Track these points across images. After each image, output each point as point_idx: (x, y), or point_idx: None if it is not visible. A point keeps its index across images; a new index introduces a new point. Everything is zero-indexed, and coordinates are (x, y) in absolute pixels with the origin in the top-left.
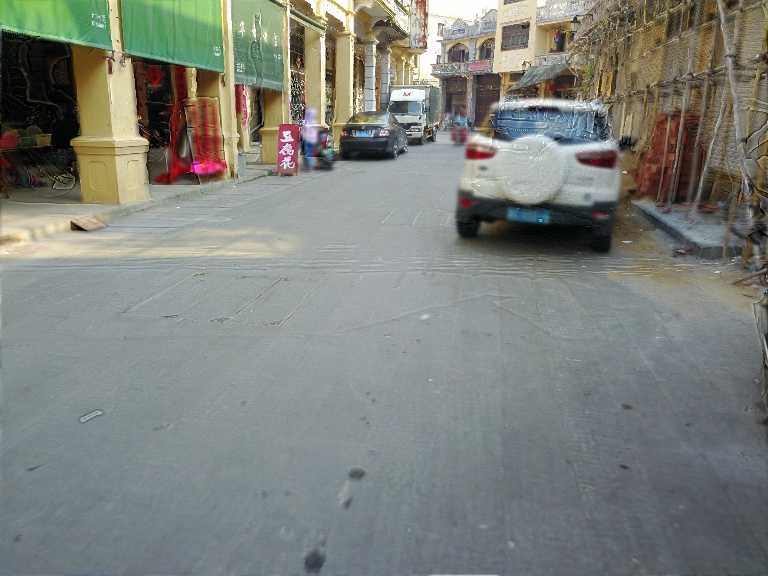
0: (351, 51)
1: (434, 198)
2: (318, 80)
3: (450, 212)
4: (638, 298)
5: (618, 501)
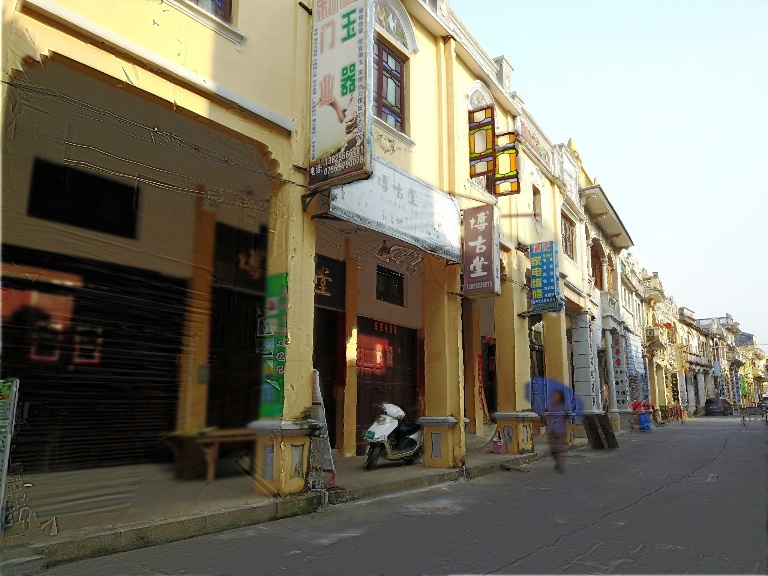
0: (753, 386)
1: None
2: (751, 394)
3: None
4: None
5: None
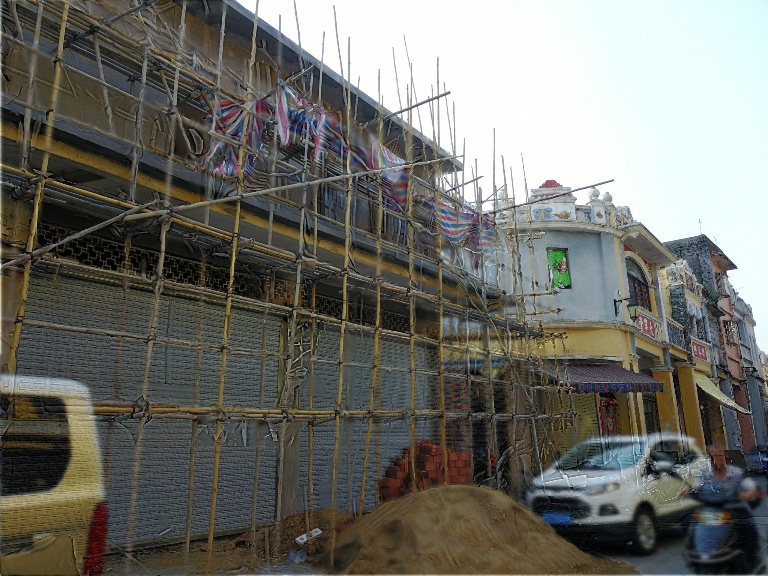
0: None
1: (737, 568)
2: None
3: (722, 552)
4: (655, 518)
5: (720, 507)
